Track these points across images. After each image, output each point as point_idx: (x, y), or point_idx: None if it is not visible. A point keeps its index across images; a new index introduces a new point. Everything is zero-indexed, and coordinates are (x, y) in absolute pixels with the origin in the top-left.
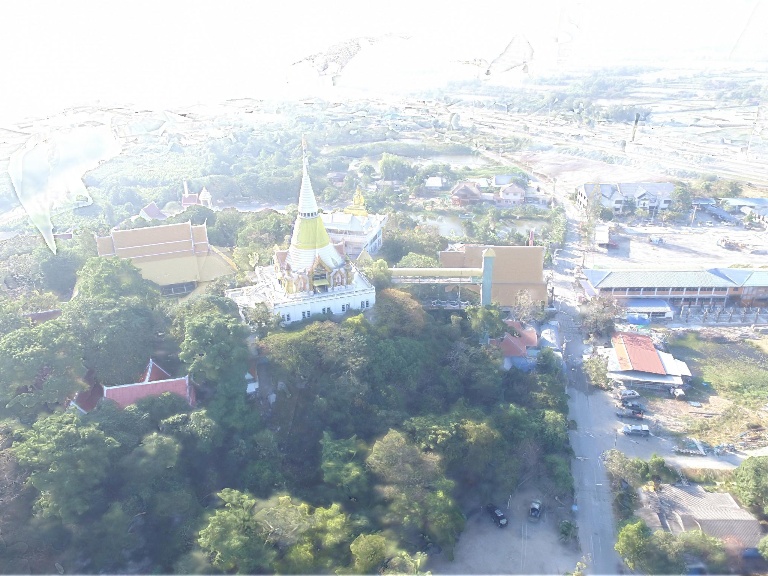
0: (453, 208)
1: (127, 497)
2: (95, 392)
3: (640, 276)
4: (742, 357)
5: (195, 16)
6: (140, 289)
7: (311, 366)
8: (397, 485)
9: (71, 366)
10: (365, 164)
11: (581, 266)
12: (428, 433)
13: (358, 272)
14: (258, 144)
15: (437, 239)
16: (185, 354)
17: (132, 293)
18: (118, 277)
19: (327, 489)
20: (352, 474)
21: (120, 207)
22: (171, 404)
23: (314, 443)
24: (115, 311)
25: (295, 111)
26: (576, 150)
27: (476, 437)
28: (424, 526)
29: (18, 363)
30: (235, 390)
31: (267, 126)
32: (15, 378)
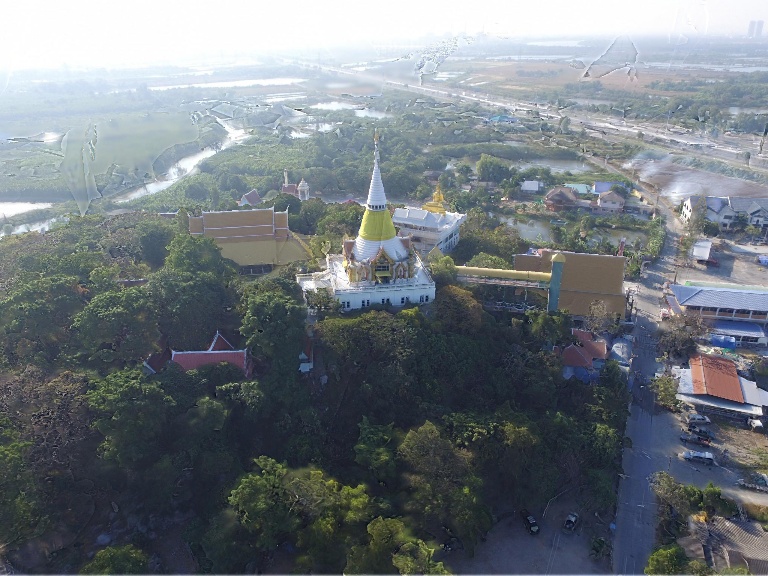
0: (546, 213)
1: (178, 452)
2: (166, 355)
3: (734, 297)
4: None
5: (311, 15)
6: (218, 266)
7: (362, 352)
8: (424, 475)
9: (147, 329)
10: (463, 164)
11: (672, 282)
12: (465, 430)
13: (423, 267)
14: (362, 140)
15: (517, 242)
16: (245, 329)
17: (209, 269)
18: (200, 254)
19: (360, 470)
20: (381, 458)
21: (226, 193)
22: (227, 373)
23: (358, 427)
24: (190, 284)
25: (405, 109)
26: (692, 160)
27: (514, 440)
28: (446, 519)
29: (102, 322)
30: (287, 367)
31: (375, 123)
32: (98, 335)
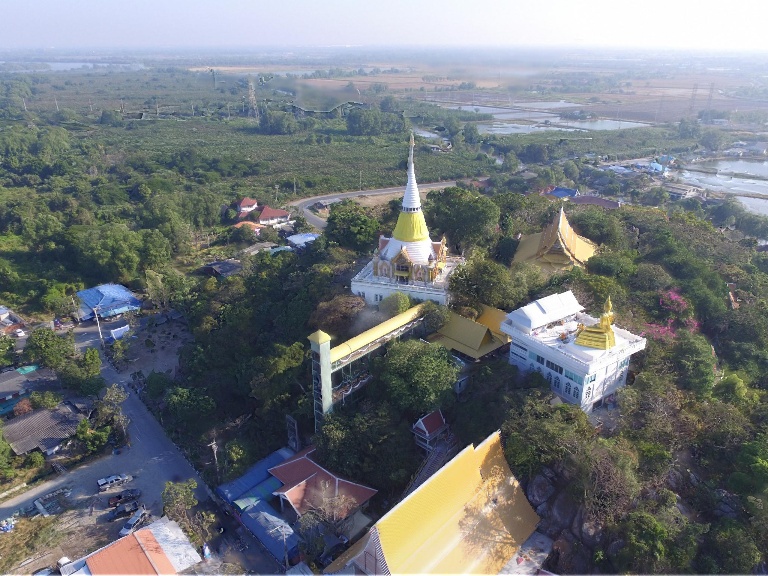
0: None
1: None
2: None
3: None
4: None
5: None
6: None
7: None
8: None
9: None
10: None
11: None
12: None
13: None
14: None
15: None
16: None
17: None
18: None
19: None
20: None
21: None
22: None
23: None
24: None
25: None
26: None
27: None
28: None
29: None
30: None
31: None
32: None
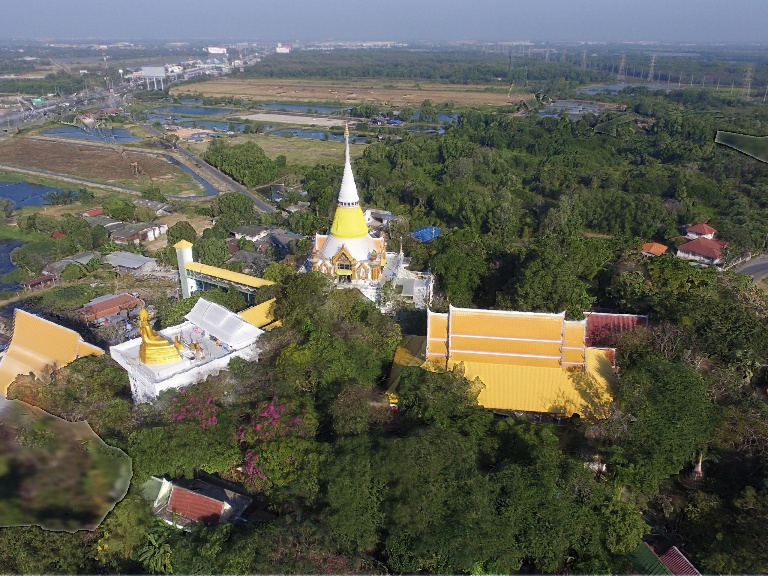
0: None
1: None
2: None
3: None
4: (28, 307)
5: None
6: None
7: None
8: None
9: None
10: None
11: None
12: None
13: None
14: None
15: None
16: None
17: None
18: None
19: None
20: None
21: None
22: None
23: None
24: None
25: None
26: None
27: None
28: None
29: None
30: None
31: None
32: None
